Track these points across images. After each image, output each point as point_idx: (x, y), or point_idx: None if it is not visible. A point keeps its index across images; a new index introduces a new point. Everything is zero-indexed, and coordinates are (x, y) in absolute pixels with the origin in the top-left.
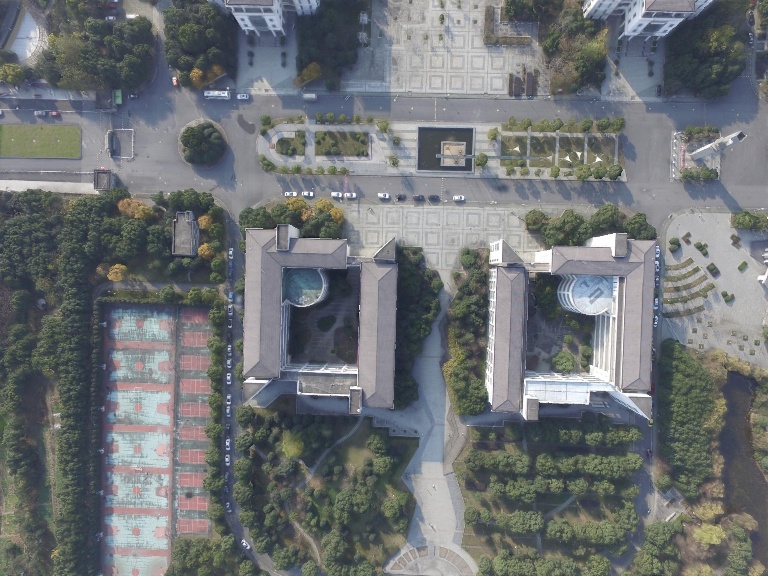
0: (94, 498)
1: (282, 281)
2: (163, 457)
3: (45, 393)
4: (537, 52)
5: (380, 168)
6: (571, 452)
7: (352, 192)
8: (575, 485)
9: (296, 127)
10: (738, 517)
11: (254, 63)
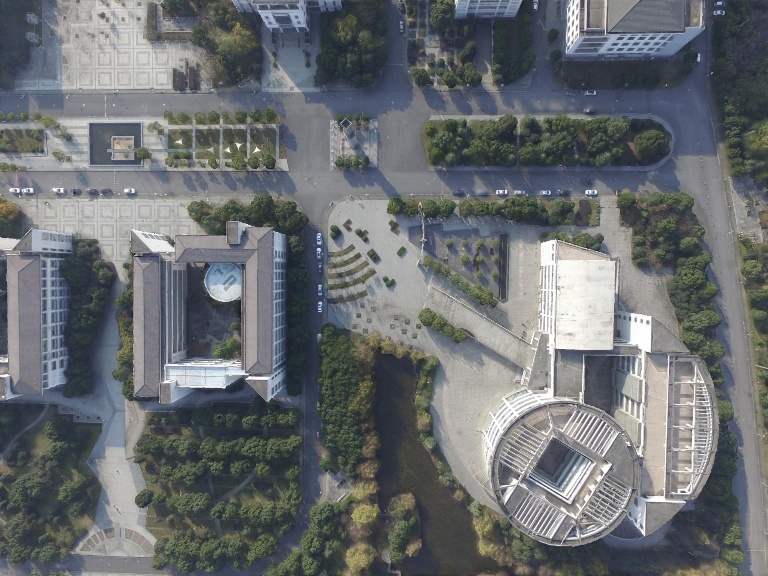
0: None
1: None
2: None
3: None
4: None
5: (55, 164)
6: (240, 435)
7: (30, 188)
8: (233, 467)
9: None
10: (405, 497)
11: None
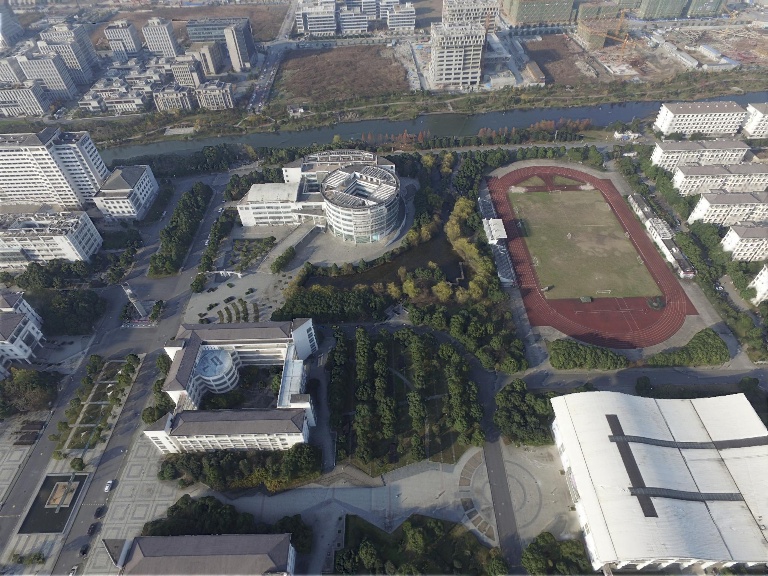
0: None
1: None
2: None
3: None
4: (7, 423)
5: None
6: None
7: None
8: (378, 369)
9: None
10: (402, 277)
11: None
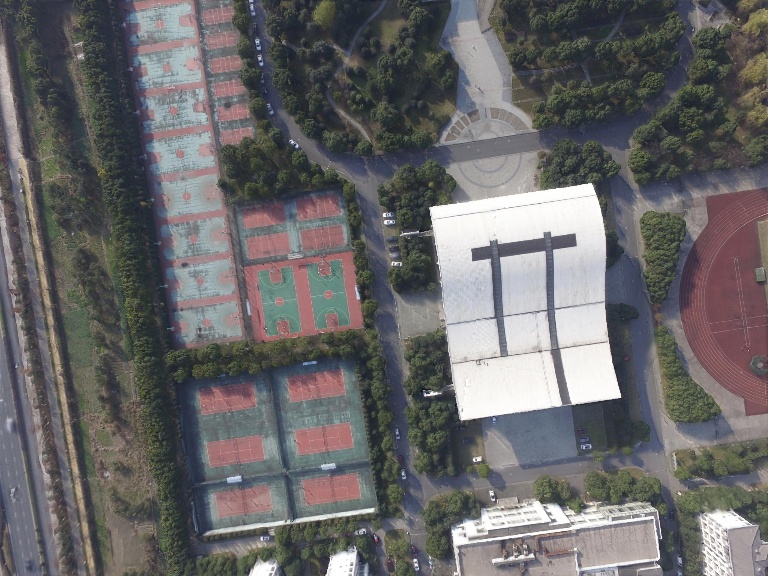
0: (131, 117)
1: None
2: (194, 71)
3: (62, 24)
4: None
5: None
6: None
7: None
8: None
9: None
10: None
11: None
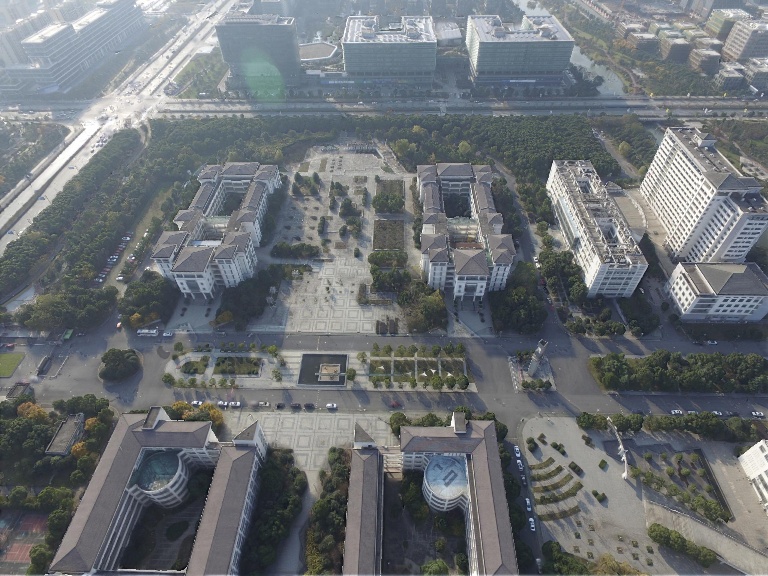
0: None
1: (139, 466)
2: None
3: None
4: (397, 308)
5: (266, 383)
6: None
7: (237, 402)
8: None
9: (203, 354)
10: None
11: (185, 315)
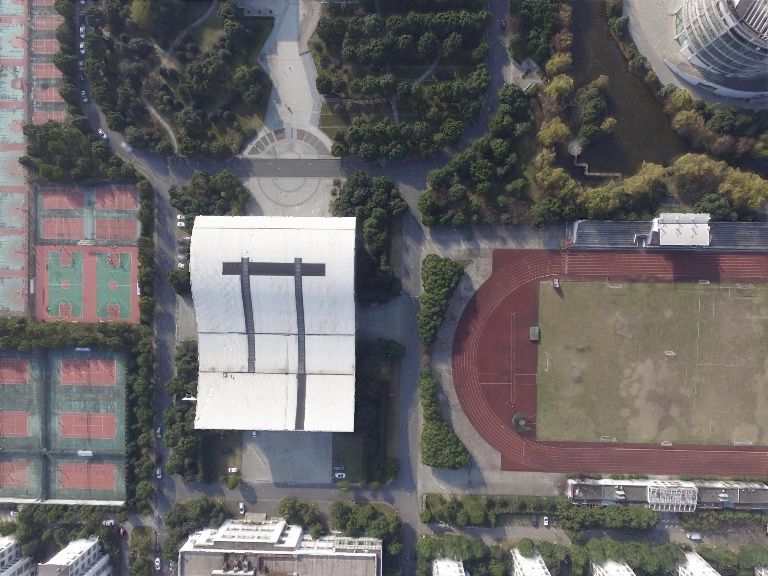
0: None
1: None
2: (18, 48)
3: None
4: None
5: None
6: None
7: None
8: (423, 38)
9: None
10: None
11: None
